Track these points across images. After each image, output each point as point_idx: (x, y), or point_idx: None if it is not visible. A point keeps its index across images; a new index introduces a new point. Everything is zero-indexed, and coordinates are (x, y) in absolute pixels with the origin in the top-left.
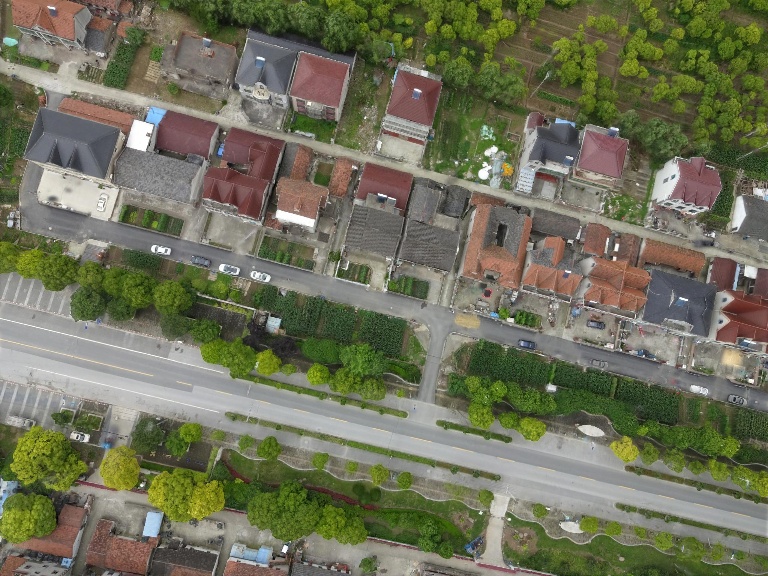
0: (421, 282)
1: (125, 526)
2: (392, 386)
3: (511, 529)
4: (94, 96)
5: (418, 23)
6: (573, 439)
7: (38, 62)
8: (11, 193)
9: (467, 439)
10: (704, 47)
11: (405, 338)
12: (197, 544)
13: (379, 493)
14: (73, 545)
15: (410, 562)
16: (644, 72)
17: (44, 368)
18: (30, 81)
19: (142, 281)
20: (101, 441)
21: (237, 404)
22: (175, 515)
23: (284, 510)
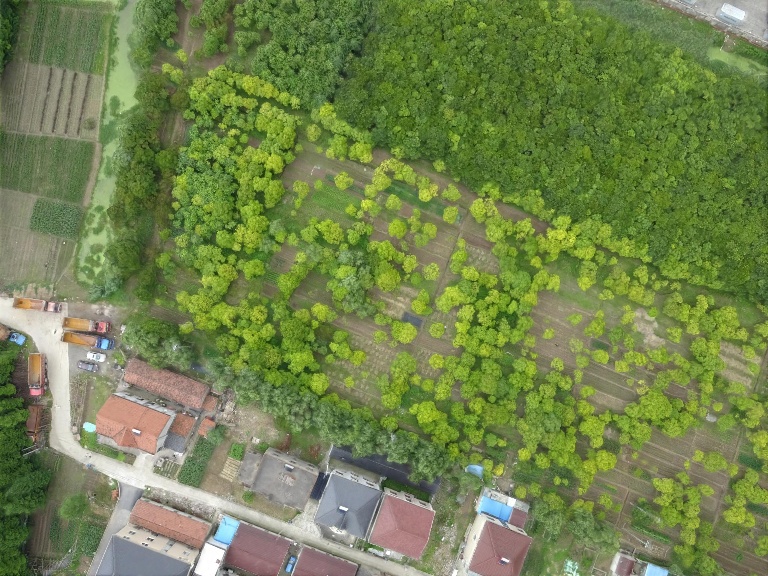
0: None
1: None
2: None
3: None
4: (167, 492)
5: None
6: None
7: (115, 454)
8: None
9: None
10: None
11: None
12: None
13: None
14: None
15: None
16: (751, 522)
17: None
18: (105, 471)
19: None
20: None
21: None
22: None
23: None
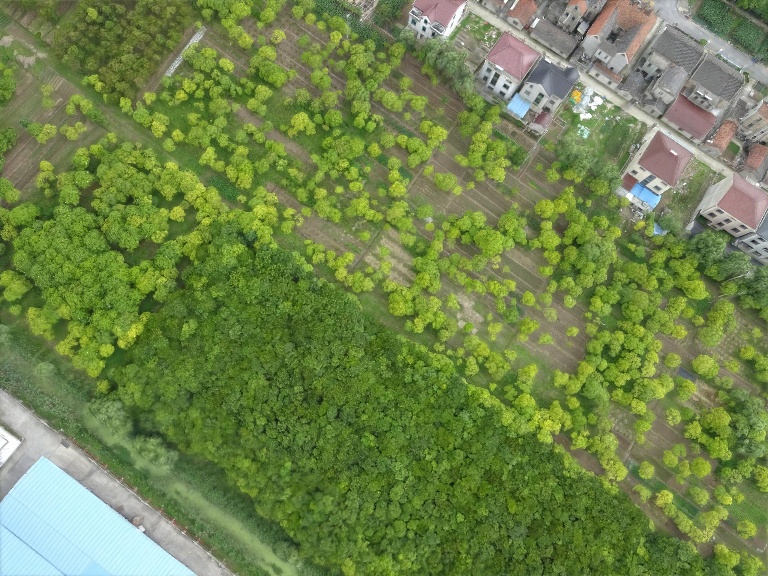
0: None
1: None
2: None
3: None
4: None
5: (626, 240)
6: None
7: None
8: None
9: None
10: (347, 135)
11: (697, 8)
12: None
13: None
14: None
15: None
16: (428, 124)
17: None
18: None
19: None
20: None
21: None
22: None
23: None
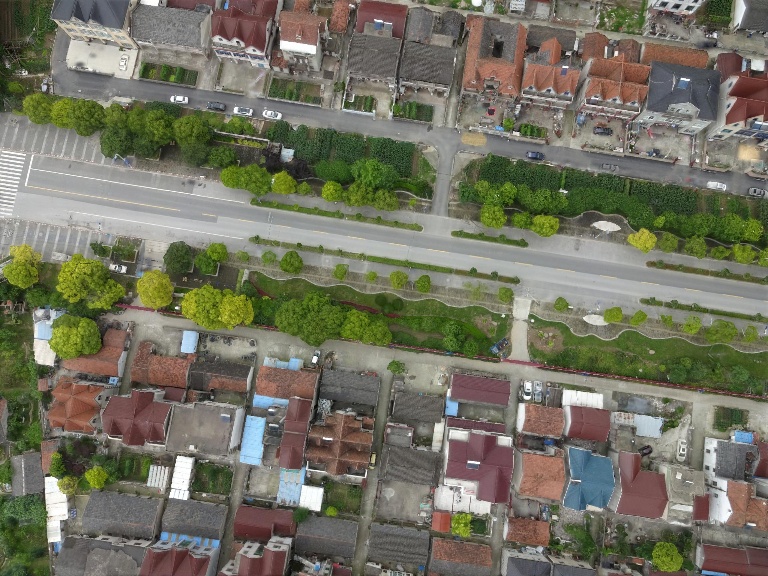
0: (425, 106)
1: (165, 348)
2: (405, 203)
3: (535, 330)
4: None
5: None
6: (590, 240)
7: None
8: (43, 63)
9: (483, 247)
10: None
11: (414, 160)
12: (232, 361)
13: (401, 302)
14: (118, 362)
15: (437, 367)
16: None
17: (82, 211)
18: None
19: (162, 116)
20: (137, 272)
21: (259, 230)
22: (207, 320)
23: (309, 312)
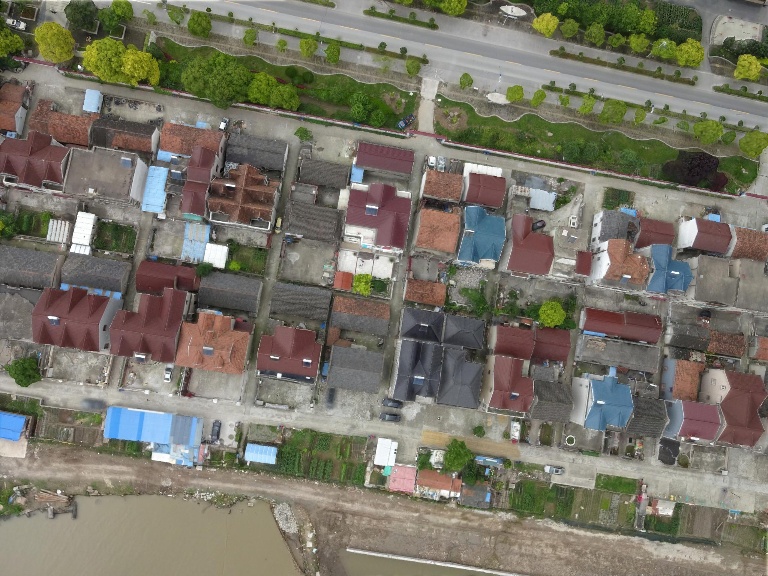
0: None
1: (67, 109)
2: None
3: (442, 109)
4: None
5: None
6: (498, 27)
7: None
8: None
9: (394, 27)
10: None
11: None
12: None
13: (311, 74)
14: (15, 115)
15: (345, 141)
16: None
17: None
18: None
19: None
20: None
21: None
22: (109, 69)
23: None
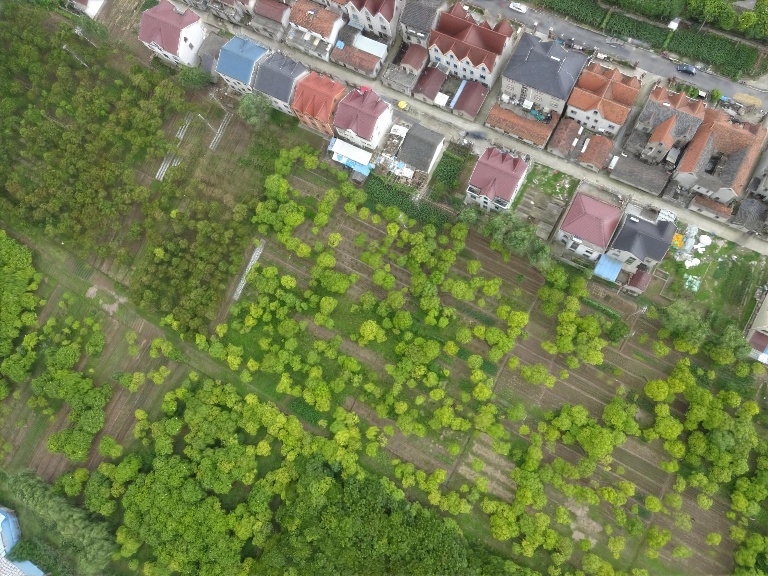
0: None
1: None
2: None
3: None
4: None
5: (767, 416)
6: None
7: None
8: None
9: None
10: (420, 333)
11: None
12: None
13: None
14: None
15: None
16: (506, 311)
17: None
18: None
19: None
20: None
21: None
22: None
23: None
